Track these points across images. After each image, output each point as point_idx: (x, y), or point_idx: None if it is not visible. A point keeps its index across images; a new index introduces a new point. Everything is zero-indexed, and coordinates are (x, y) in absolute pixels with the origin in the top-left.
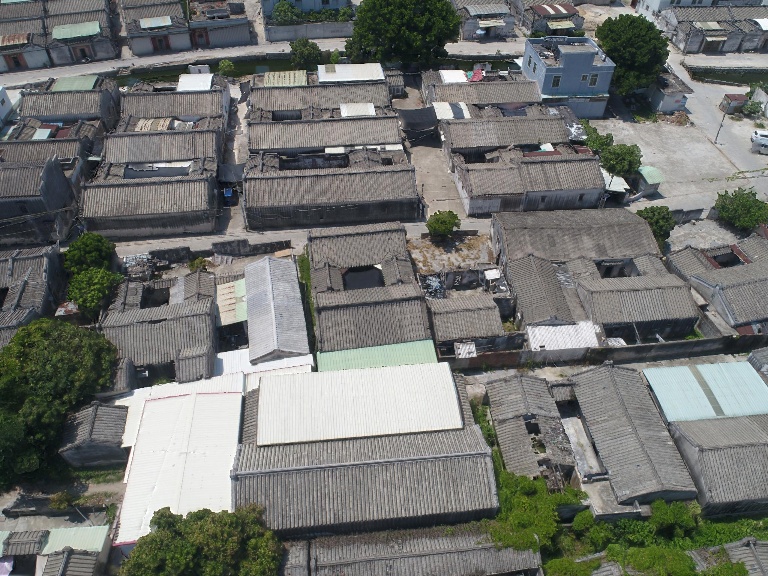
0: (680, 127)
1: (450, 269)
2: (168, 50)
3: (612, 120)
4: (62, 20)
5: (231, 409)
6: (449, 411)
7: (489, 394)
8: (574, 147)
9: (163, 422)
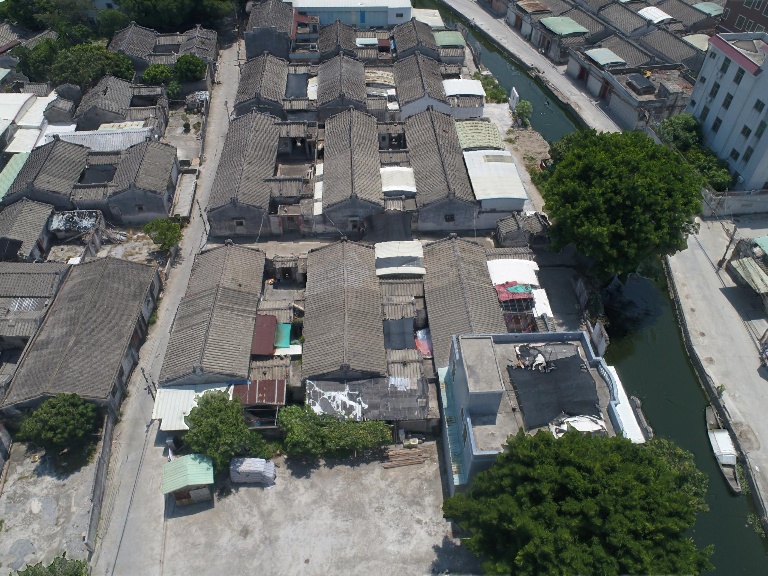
0: None
1: (90, 228)
2: (585, 86)
3: (443, 524)
4: (578, 16)
5: (3, 117)
6: None
7: None
8: None
9: (12, 98)
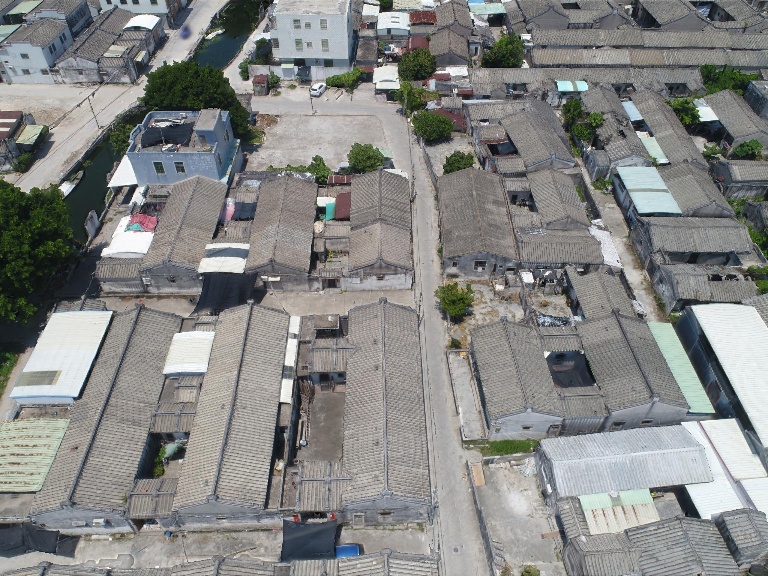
0: (279, 124)
1: None
2: None
3: (251, 157)
4: None
5: None
6: (745, 311)
7: (688, 298)
8: (331, 183)
9: None
